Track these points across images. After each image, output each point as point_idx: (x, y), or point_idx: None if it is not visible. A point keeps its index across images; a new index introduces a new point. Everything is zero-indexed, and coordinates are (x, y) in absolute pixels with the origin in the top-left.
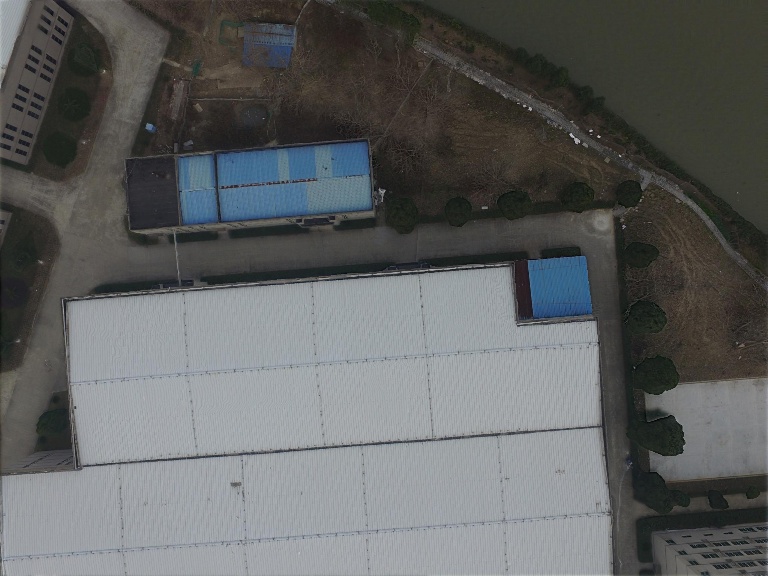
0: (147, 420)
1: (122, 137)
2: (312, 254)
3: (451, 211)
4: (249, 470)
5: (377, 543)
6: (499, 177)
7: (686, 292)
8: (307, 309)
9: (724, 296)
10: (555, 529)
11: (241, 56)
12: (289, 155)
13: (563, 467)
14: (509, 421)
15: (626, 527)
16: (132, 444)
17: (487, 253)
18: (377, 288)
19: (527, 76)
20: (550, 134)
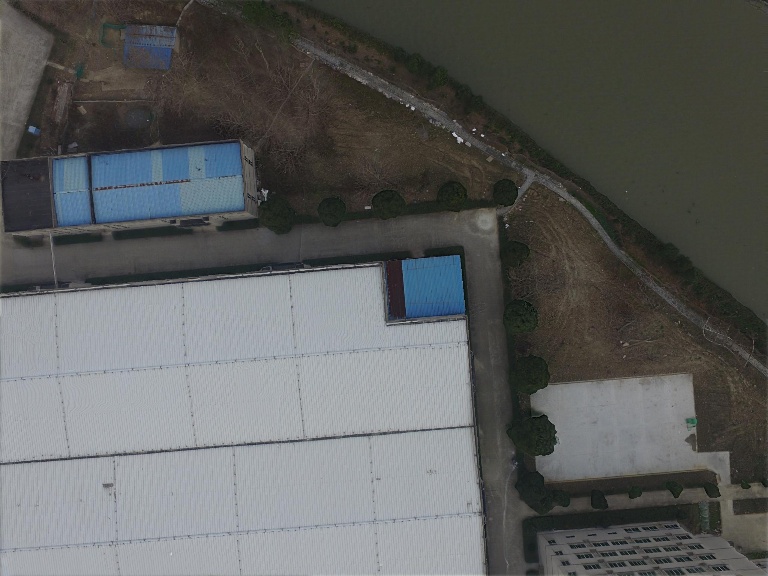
0: (19, 421)
1: (7, 140)
2: (196, 255)
3: (321, 211)
4: (121, 471)
5: (248, 544)
6: (381, 177)
7: (567, 291)
8: (177, 310)
9: (606, 295)
10: (426, 529)
11: (122, 58)
12: (163, 156)
13: (434, 467)
14: (380, 421)
15: (512, 527)
16: (5, 445)
17: (371, 253)
18: (247, 288)
19: (410, 75)
20: (432, 133)
